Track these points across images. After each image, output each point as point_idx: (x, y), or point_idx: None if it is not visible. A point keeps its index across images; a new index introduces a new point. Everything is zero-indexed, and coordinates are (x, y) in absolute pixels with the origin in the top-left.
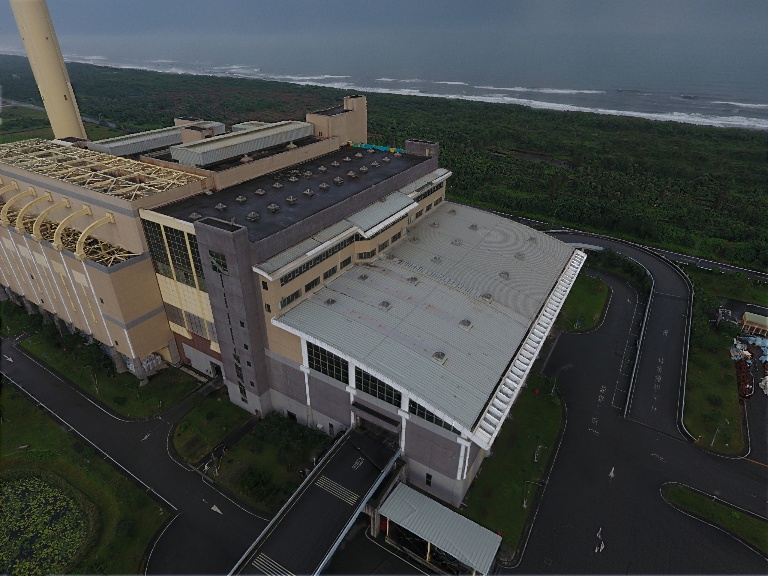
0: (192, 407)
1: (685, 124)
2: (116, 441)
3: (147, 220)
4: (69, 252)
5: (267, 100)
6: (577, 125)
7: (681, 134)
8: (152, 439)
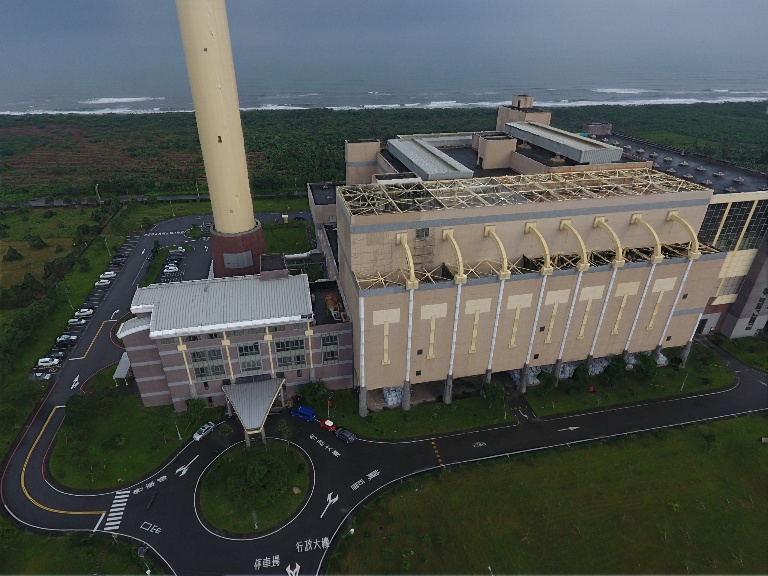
0: (730, 355)
1: (453, 109)
2: (764, 397)
3: (714, 204)
4: (670, 259)
5: (11, 138)
6: (392, 119)
7: (460, 116)
8: (767, 381)
